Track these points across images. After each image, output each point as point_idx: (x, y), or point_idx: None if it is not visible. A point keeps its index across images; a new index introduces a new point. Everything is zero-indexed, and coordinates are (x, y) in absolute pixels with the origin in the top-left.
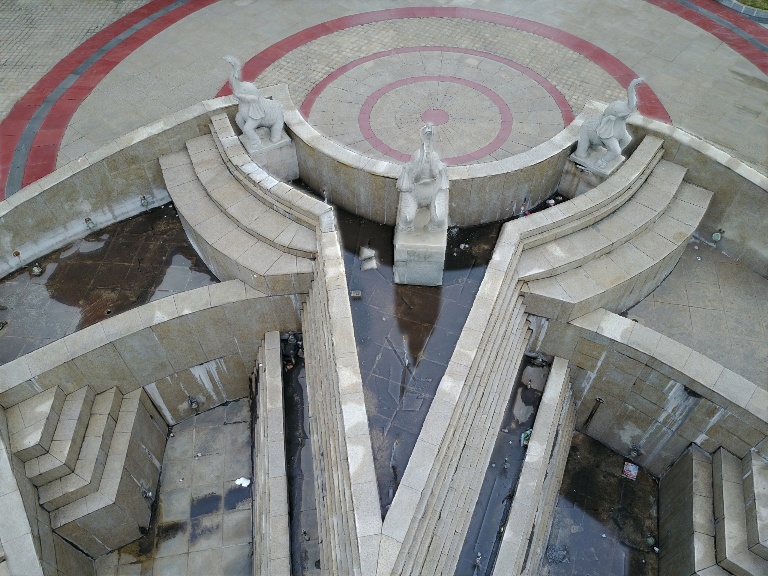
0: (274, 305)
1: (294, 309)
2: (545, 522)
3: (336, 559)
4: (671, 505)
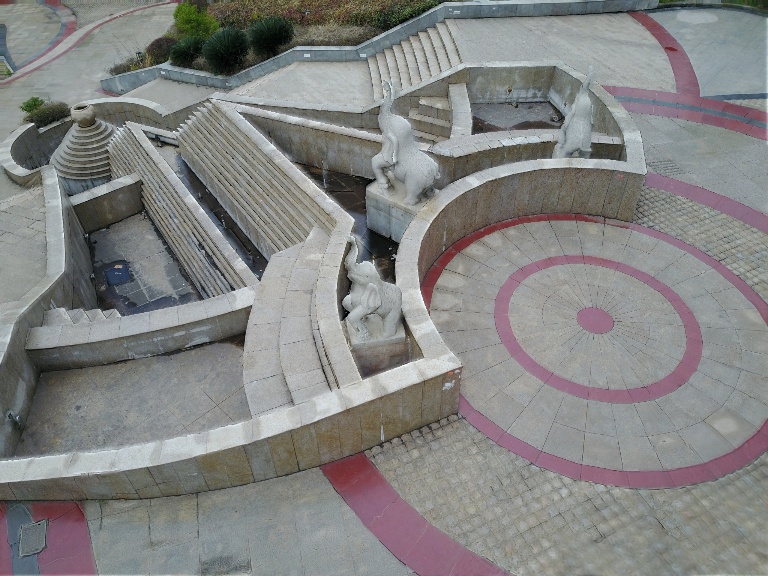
0: None
1: None
2: None
3: None
4: None
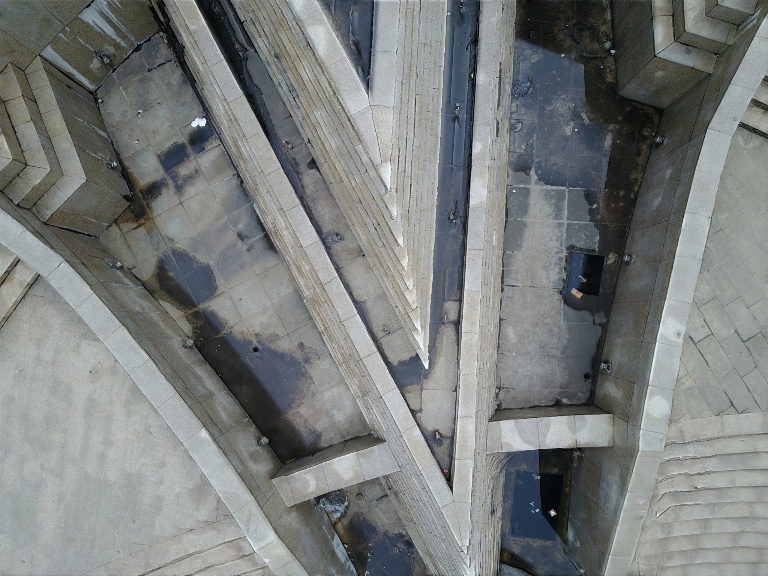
0: None
1: None
2: (508, 58)
3: (331, 148)
4: (626, 1)
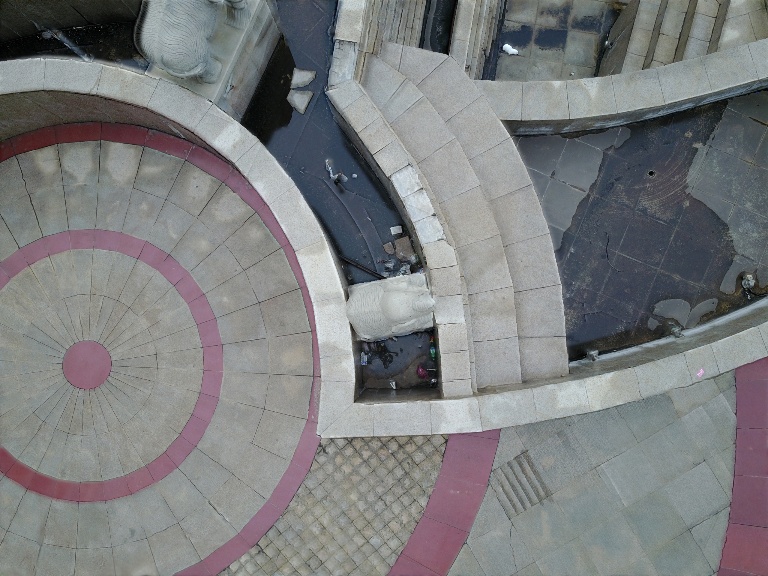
0: None
1: None
2: None
3: None
4: None
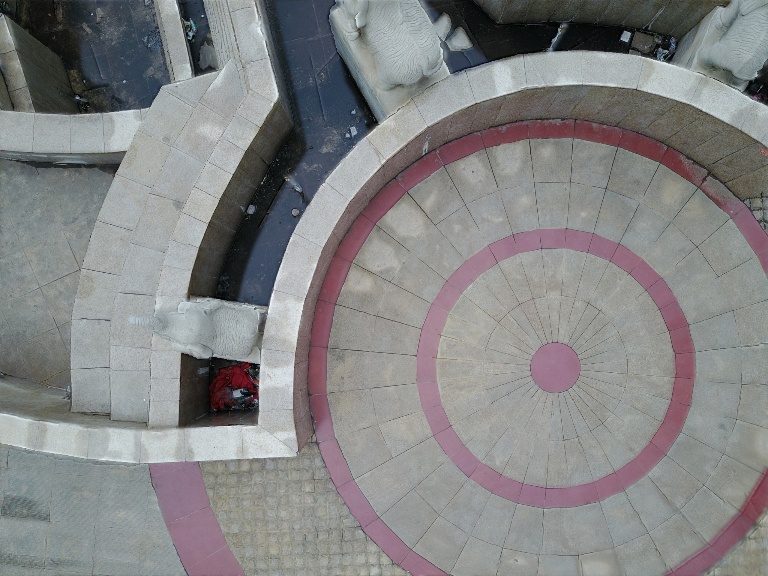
0: None
1: None
2: None
3: None
4: None
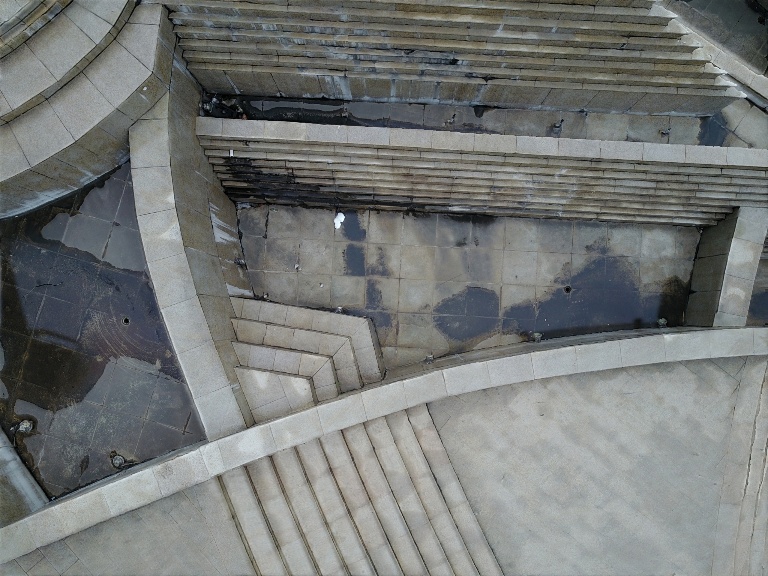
0: (176, 94)
1: (184, 75)
2: None
3: None
4: None
